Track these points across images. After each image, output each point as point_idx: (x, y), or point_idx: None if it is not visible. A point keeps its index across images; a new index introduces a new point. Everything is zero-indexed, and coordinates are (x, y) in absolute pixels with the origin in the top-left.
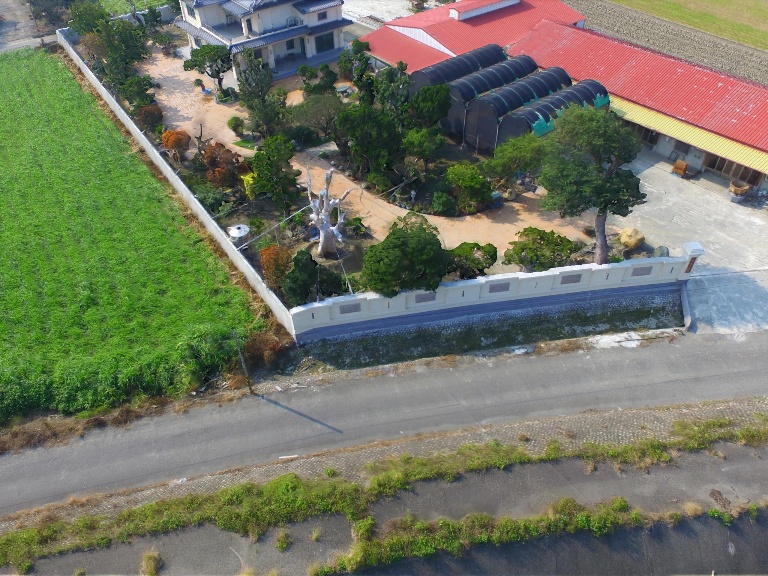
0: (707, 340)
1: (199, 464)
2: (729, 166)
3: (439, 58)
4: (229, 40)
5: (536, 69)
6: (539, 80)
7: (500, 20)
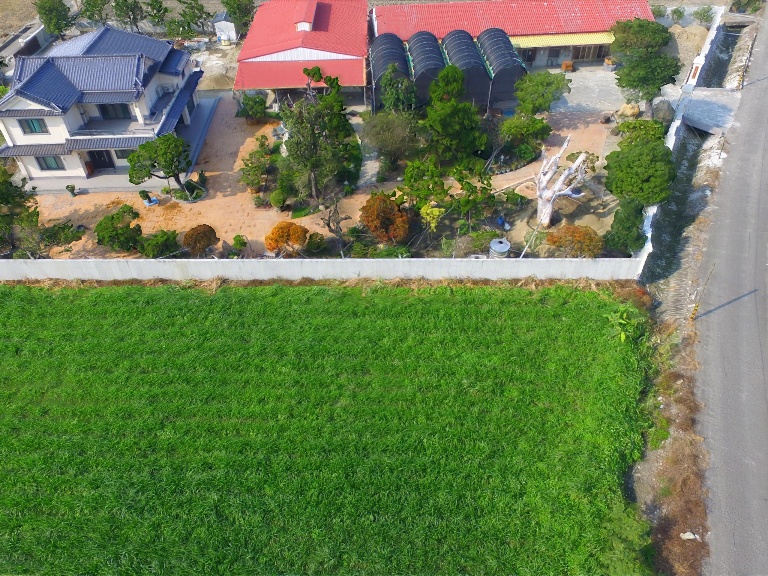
0: (734, 133)
1: (765, 372)
2: (589, 52)
3: (342, 65)
4: (151, 130)
5: None
6: (468, 41)
7: (331, 21)
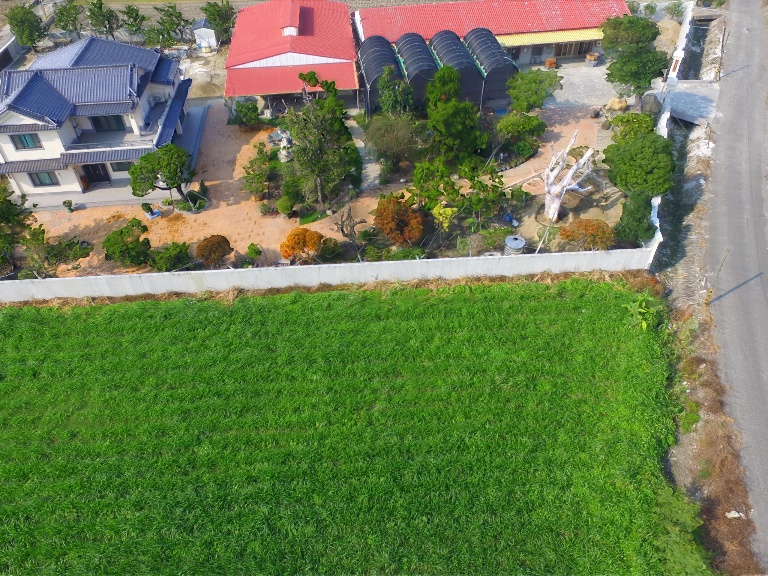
0: (718, 123)
1: None
2: (570, 49)
3: (332, 69)
4: (150, 141)
5: (424, 40)
6: (456, 42)
7: (316, 25)
